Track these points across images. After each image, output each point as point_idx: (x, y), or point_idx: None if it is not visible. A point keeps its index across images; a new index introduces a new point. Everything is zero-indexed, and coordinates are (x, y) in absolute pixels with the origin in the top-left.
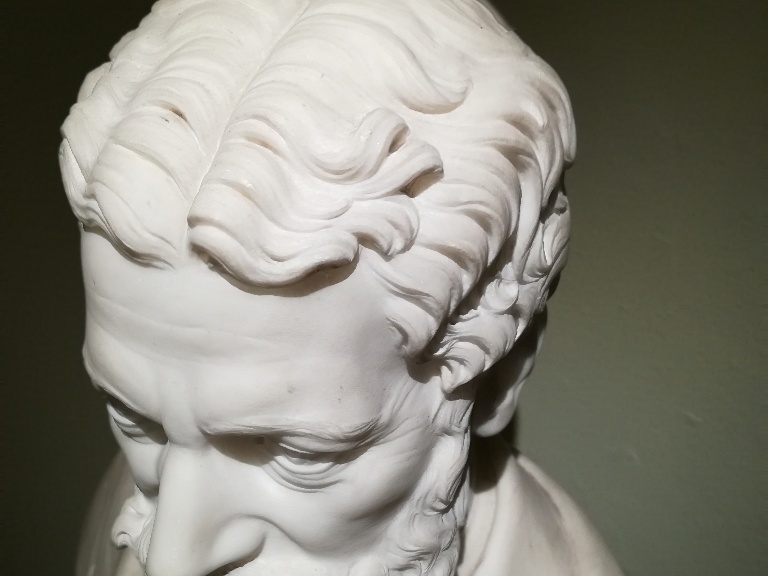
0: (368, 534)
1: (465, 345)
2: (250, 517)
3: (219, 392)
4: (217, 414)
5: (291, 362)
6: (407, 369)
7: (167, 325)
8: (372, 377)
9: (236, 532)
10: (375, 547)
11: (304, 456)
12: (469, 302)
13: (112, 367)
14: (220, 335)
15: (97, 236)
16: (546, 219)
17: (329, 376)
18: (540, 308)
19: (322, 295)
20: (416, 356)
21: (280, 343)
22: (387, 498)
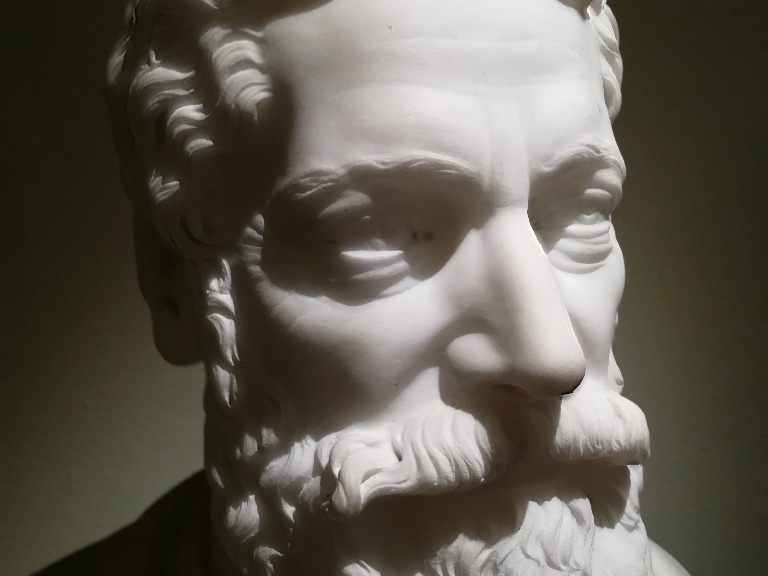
0: None
1: None
2: None
3: (560, 109)
4: (563, 135)
5: (591, 83)
6: None
7: (500, 43)
8: None
9: None
10: (607, 377)
11: (599, 208)
12: None
13: (433, 118)
14: (549, 46)
15: None
16: None
17: None
18: None
19: (587, 26)
20: None
21: (584, 60)
22: None
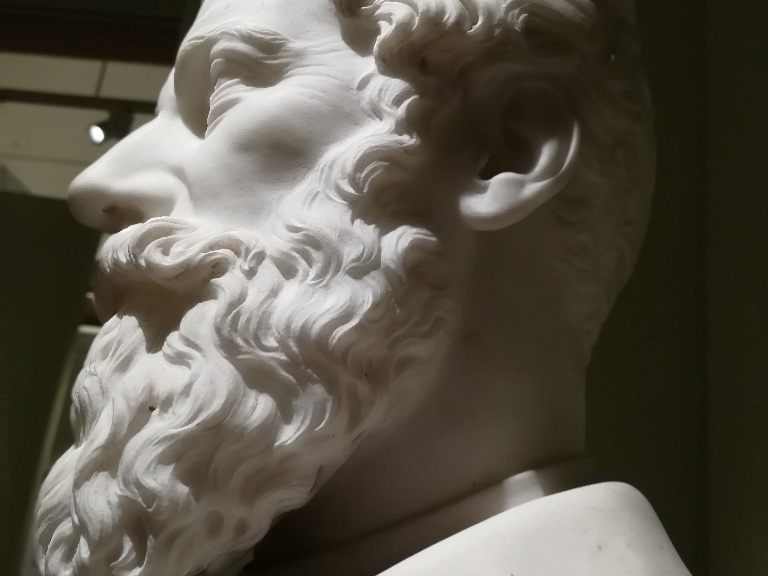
0: (256, 192)
1: None
2: (172, 173)
3: None
4: None
5: None
6: (341, 32)
7: None
8: (298, 14)
9: None
10: (262, 223)
11: None
12: None
13: None
14: None
15: None
16: None
17: None
18: (511, 22)
19: None
20: None
21: None
22: (277, 128)
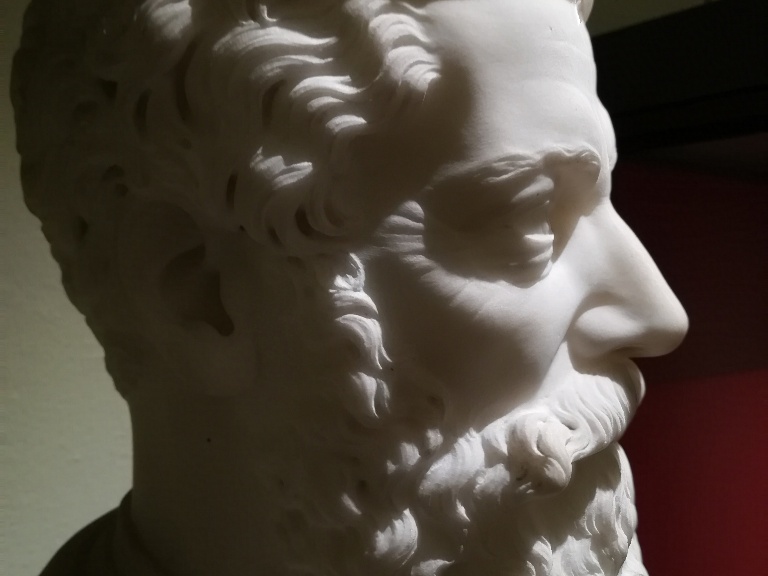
0: None
1: None
2: None
3: None
4: None
5: None
6: None
7: None
8: None
9: None
10: None
11: None
12: None
13: (588, 115)
14: None
15: None
16: None
17: None
18: None
19: None
20: None
21: None
22: None
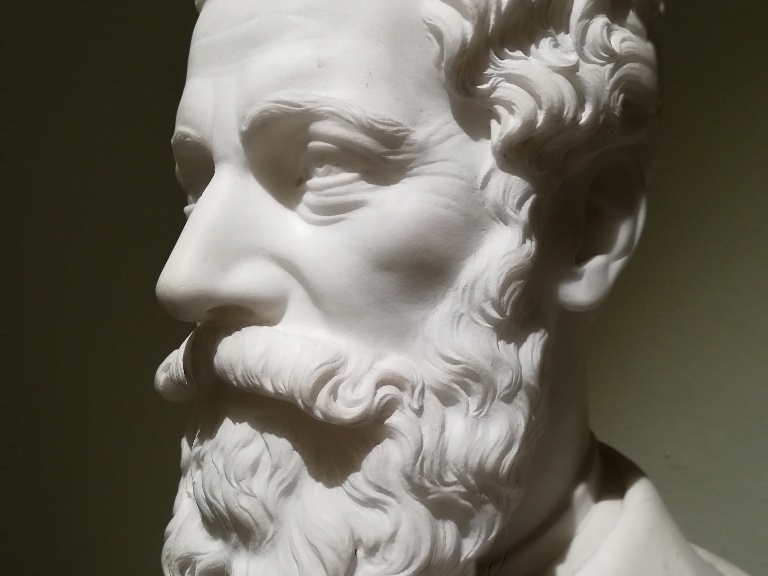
0: (399, 313)
1: (513, 87)
2: (274, 261)
3: (258, 73)
4: (253, 96)
5: (325, 40)
6: (451, 108)
7: (231, 30)
8: (407, 86)
9: (256, 269)
10: (409, 345)
11: (330, 161)
12: (516, 42)
13: (185, 101)
14: (269, 19)
15: (204, 6)
16: (615, 24)
17: (359, 59)
18: (612, 107)
19: None
20: (453, 69)
21: (317, 20)
22: (419, 247)
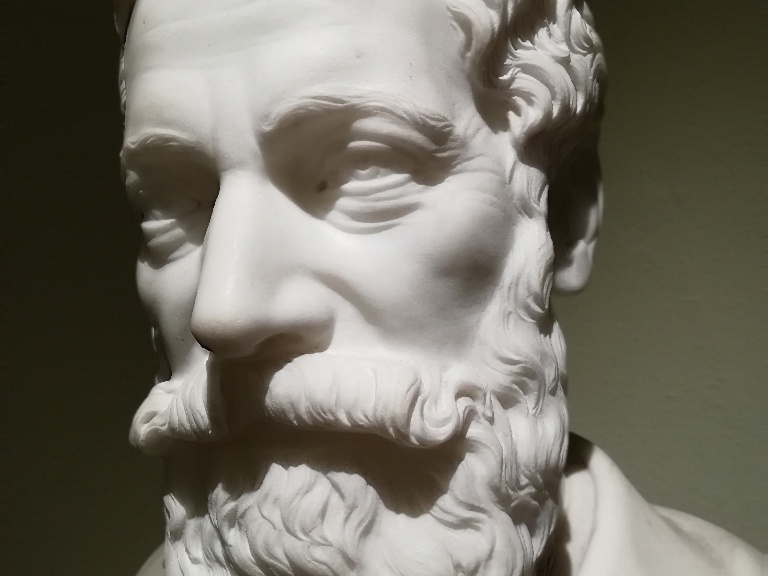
0: (458, 319)
1: (529, 78)
2: (316, 279)
3: (281, 65)
4: (279, 91)
5: (356, 27)
6: (473, 100)
7: (224, 13)
8: (440, 78)
9: (301, 289)
10: (468, 352)
11: (377, 161)
12: (524, 32)
13: (159, 97)
14: (281, 2)
15: None
16: None
17: (397, 49)
18: (594, 96)
19: None
20: (482, 60)
21: (344, 4)
22: (475, 248)
